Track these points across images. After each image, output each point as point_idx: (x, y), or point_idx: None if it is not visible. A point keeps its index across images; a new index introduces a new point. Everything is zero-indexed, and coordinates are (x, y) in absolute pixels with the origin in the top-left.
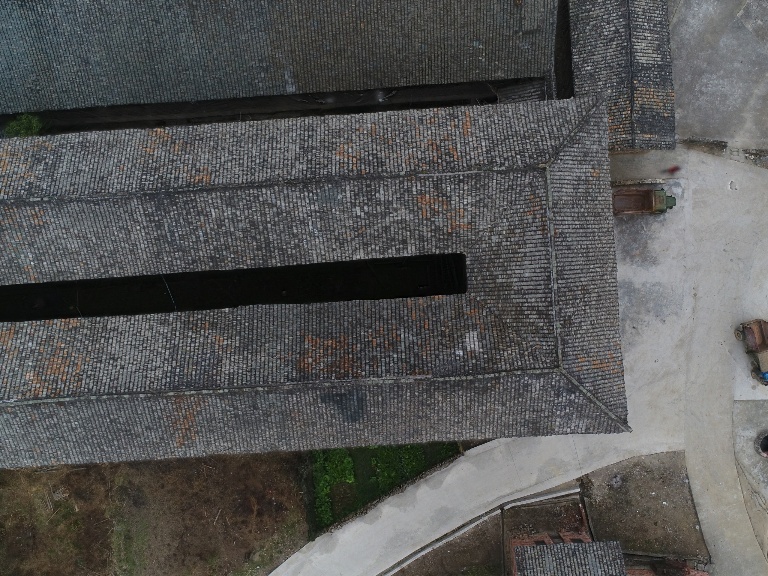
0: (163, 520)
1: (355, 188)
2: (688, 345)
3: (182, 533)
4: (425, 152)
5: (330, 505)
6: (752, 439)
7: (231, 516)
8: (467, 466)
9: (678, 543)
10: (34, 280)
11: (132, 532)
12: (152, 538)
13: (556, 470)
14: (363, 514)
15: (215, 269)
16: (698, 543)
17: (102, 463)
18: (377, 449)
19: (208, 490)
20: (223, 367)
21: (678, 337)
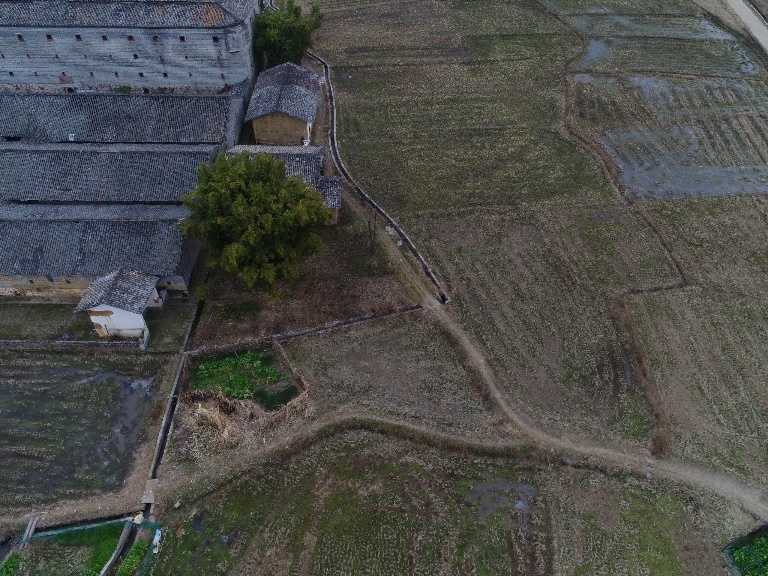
0: None
1: None
2: None
3: None
4: None
5: None
6: None
7: None
8: None
9: None
10: None
11: None
12: None
13: None
14: None
15: None
16: None
17: None
18: None
19: None
20: None
21: None
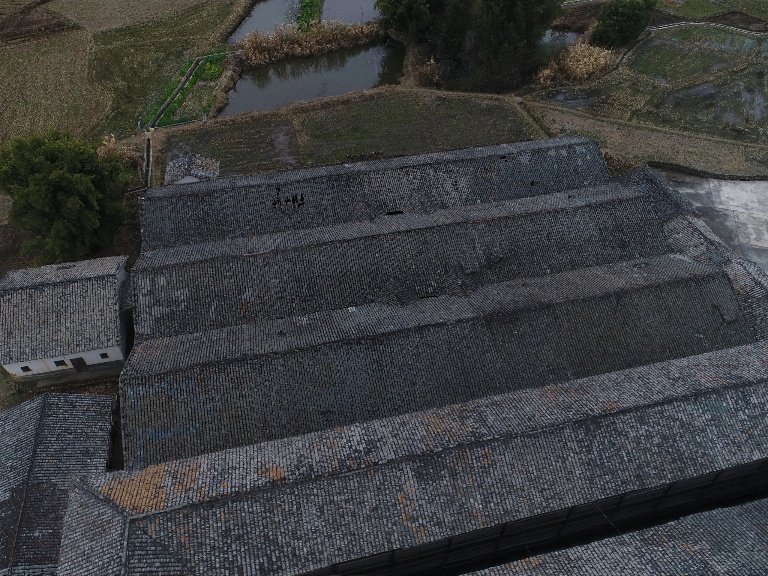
0: None
1: (733, 395)
2: None
3: None
4: (764, 367)
5: None
6: None
7: None
8: None
9: None
10: (482, 525)
11: None
12: None
13: None
14: None
15: (643, 487)
16: None
17: None
18: None
19: None
20: (714, 568)
21: None
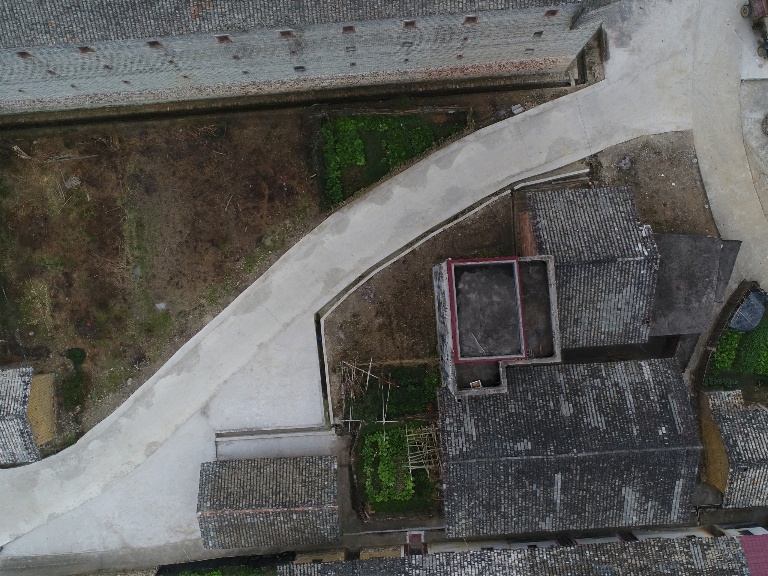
0: (175, 207)
1: None
2: (695, 25)
3: (194, 220)
4: None
5: (341, 187)
6: (759, 121)
7: (242, 202)
8: (477, 146)
9: (687, 224)
10: None
11: (144, 220)
12: (164, 226)
13: (565, 149)
14: (374, 183)
15: None
16: (707, 223)
17: (114, 147)
18: (387, 131)
19: (219, 176)
20: None
21: (685, 17)
